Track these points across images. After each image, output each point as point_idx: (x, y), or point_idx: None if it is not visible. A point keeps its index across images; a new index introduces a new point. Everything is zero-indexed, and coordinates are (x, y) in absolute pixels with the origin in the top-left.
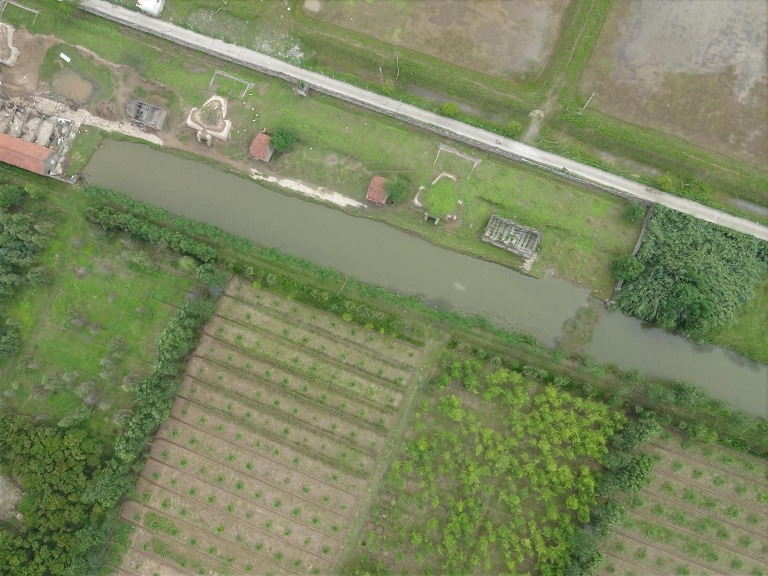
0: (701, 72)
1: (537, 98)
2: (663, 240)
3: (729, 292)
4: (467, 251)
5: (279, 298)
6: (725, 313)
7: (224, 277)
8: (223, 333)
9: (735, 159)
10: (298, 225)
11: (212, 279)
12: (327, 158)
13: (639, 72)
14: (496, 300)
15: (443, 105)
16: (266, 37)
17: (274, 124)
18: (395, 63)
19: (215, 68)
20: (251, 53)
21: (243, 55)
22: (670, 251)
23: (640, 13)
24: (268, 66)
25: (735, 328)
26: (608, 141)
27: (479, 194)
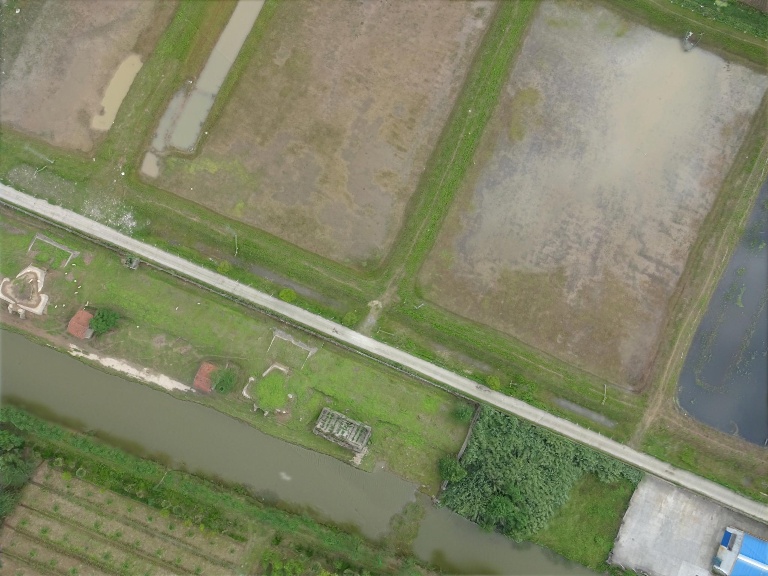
0: (534, 271)
1: (376, 288)
2: (486, 446)
3: (543, 503)
4: (297, 442)
5: (93, 487)
6: (538, 523)
7: (28, 468)
8: (26, 525)
9: (561, 359)
10: (119, 408)
11: (14, 470)
12: (154, 339)
13: (477, 267)
14: (324, 494)
15: (281, 289)
16: (96, 202)
17: (98, 299)
18: (233, 242)
19: (36, 231)
20: (78, 217)
21: (69, 219)
22: (491, 458)
23: (481, 208)
24: (96, 233)
25: (551, 529)
26: (442, 337)
27: (312, 385)
